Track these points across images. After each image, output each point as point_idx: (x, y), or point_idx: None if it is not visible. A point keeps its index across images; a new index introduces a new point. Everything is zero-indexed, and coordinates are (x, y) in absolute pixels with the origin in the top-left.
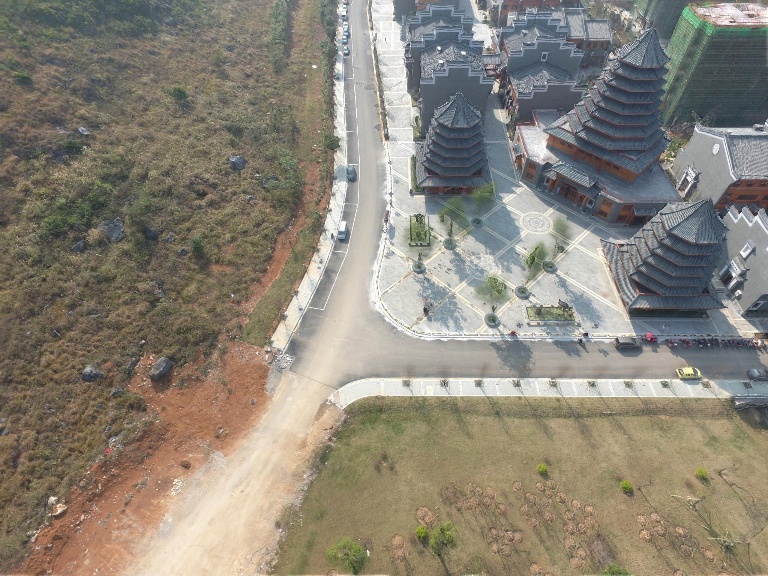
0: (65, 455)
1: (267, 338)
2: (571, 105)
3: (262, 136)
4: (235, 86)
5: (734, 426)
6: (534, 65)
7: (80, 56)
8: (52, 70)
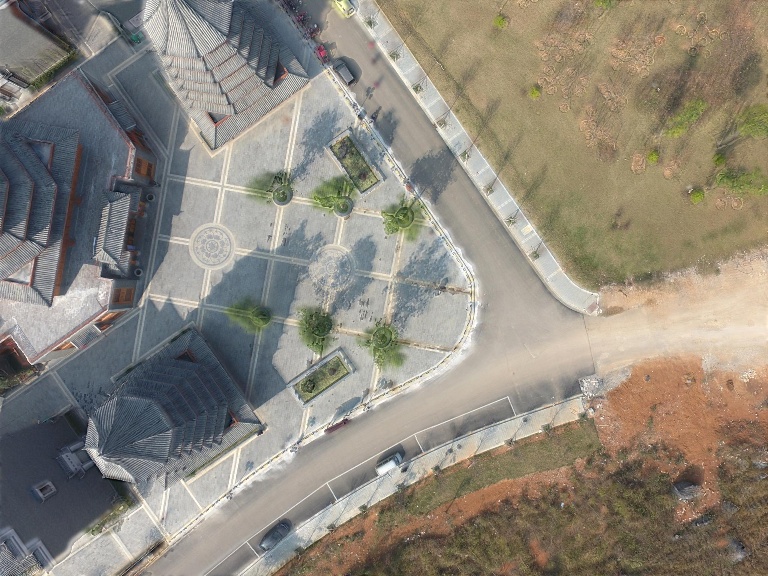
0: None
1: None
2: None
3: None
4: None
5: None
6: None
7: None
8: None
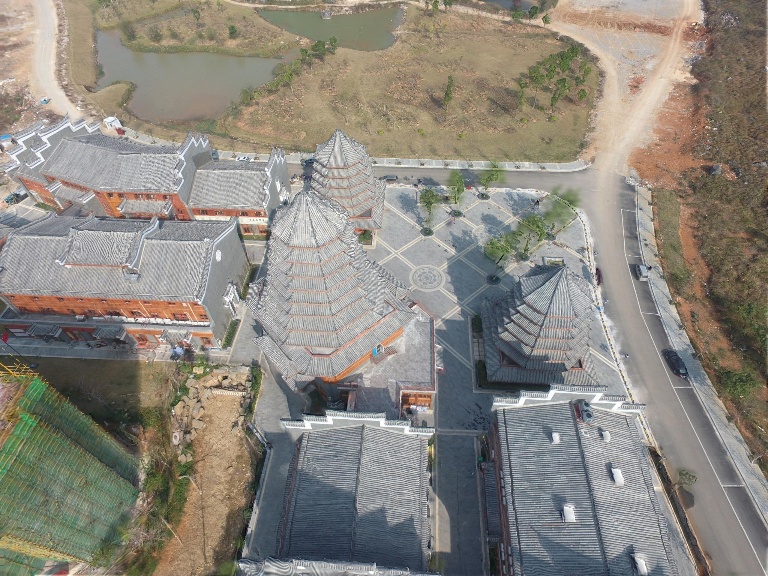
0: None
1: None
2: None
3: None
4: None
5: None
6: (371, 557)
7: None
8: None
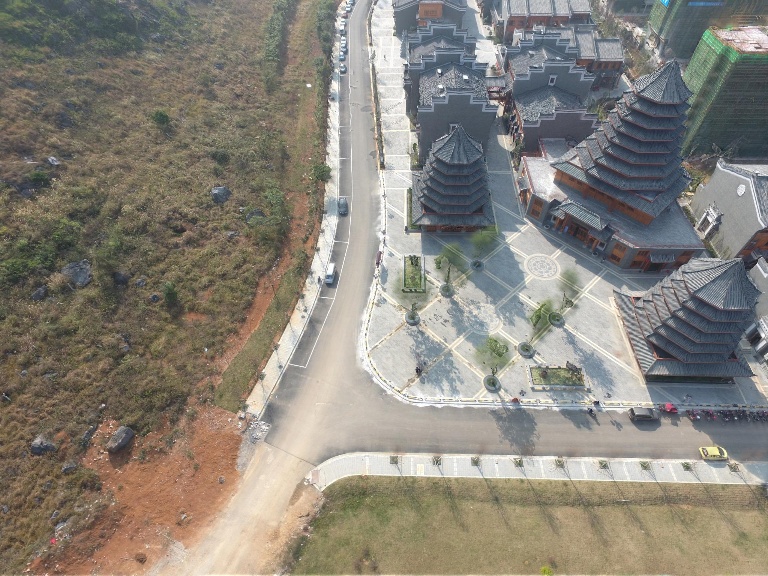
0: (4, 547)
1: (241, 403)
2: (581, 134)
3: (249, 163)
4: (223, 107)
5: (767, 520)
6: (541, 89)
7: (55, 78)
8: (23, 94)
